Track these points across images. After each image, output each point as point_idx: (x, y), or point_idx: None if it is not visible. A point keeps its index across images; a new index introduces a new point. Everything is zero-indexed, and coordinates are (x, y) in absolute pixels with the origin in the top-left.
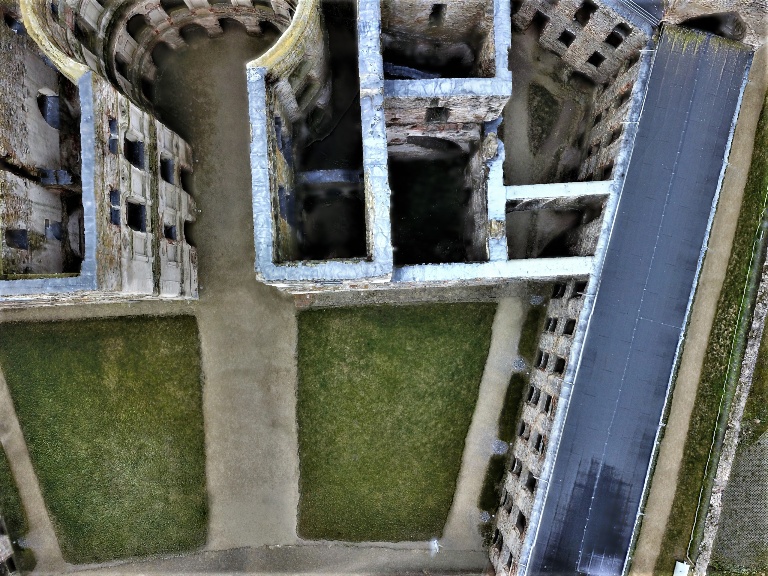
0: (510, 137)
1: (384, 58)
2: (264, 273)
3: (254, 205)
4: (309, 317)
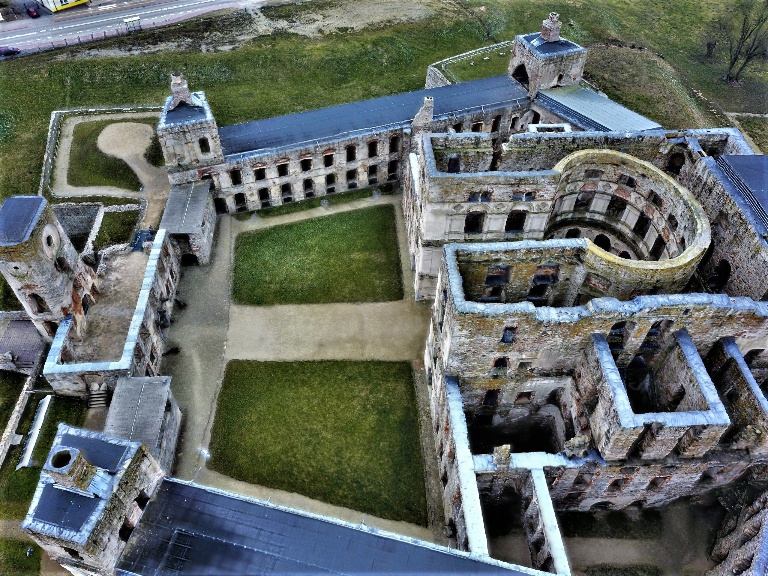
0: (597, 544)
1: (631, 391)
2: (450, 245)
3: None
4: (406, 369)
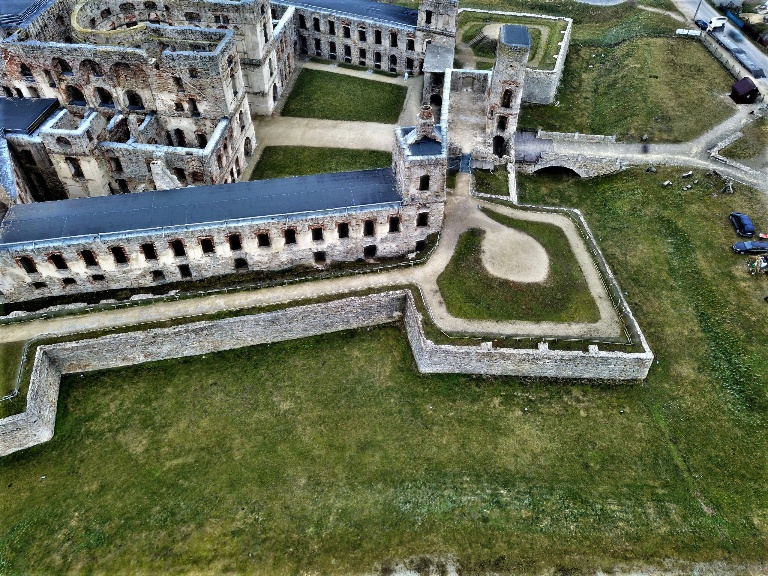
0: None
1: None
2: (251, 1)
3: (223, 3)
4: (285, 113)
